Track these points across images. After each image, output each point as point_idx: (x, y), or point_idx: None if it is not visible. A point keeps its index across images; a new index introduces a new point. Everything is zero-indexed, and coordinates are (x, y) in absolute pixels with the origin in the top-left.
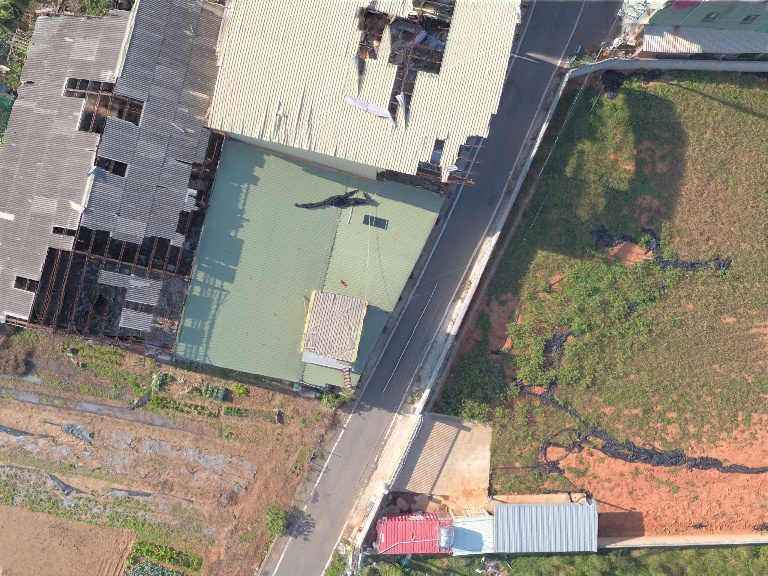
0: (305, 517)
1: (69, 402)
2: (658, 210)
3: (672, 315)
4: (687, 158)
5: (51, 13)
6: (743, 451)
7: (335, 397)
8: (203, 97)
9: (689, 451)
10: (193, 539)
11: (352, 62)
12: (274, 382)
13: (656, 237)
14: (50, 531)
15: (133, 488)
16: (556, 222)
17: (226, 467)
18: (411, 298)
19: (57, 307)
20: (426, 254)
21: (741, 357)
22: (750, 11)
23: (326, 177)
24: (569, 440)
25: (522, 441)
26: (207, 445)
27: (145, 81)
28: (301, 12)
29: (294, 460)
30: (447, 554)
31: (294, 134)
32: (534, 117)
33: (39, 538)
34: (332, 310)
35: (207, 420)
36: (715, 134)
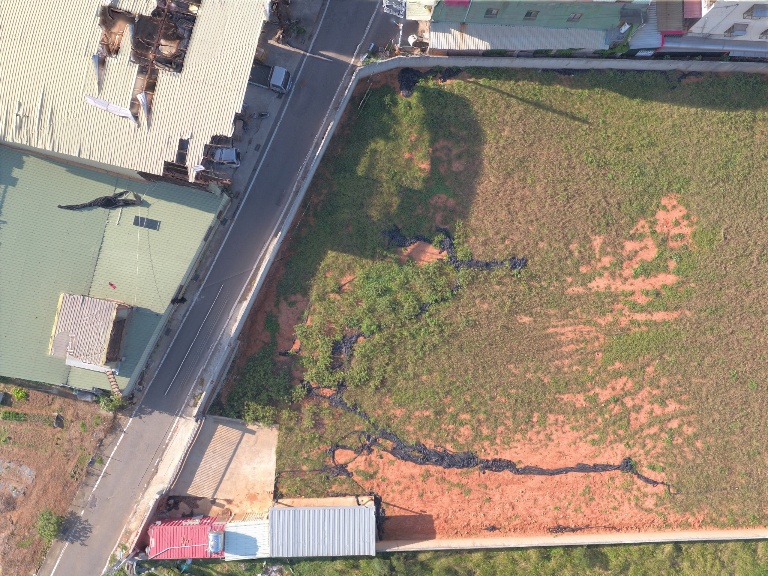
0: (82, 522)
1: None
2: (453, 209)
3: (465, 315)
4: (483, 156)
5: None
6: (538, 452)
7: (110, 400)
8: None
9: (482, 453)
10: None
11: (92, 61)
12: (54, 386)
13: (450, 236)
14: None
15: None
16: (347, 222)
17: (4, 472)
18: (196, 300)
19: None
20: (212, 255)
21: (537, 357)
22: (526, 7)
23: (92, 178)
24: (358, 442)
25: (309, 444)
26: None
27: None
28: (40, 11)
29: (73, 464)
30: (219, 559)
31: (36, 135)
32: (326, 116)
33: None
34: (80, 313)
35: None
36: (513, 132)
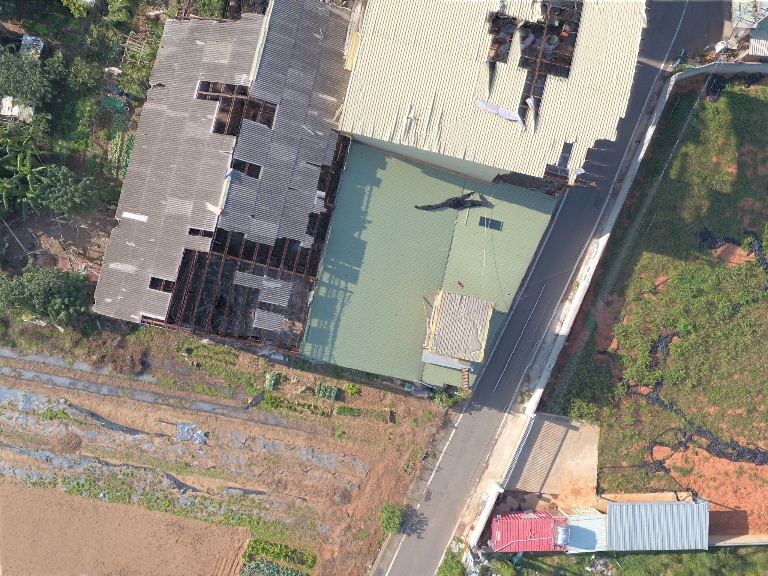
0: (418, 515)
1: (184, 401)
2: (760, 212)
3: None
4: None
5: (180, 16)
6: None
7: (449, 397)
8: (332, 100)
9: None
10: (307, 537)
11: (483, 66)
12: (385, 382)
13: (758, 239)
14: (167, 529)
15: (248, 486)
16: (660, 224)
17: (339, 466)
18: (519, 299)
19: (195, 308)
20: (534, 255)
21: None
22: None
23: (444, 179)
24: (674, 439)
25: (629, 440)
26: (320, 444)
27: (278, 84)
28: (432, 16)
29: (406, 459)
30: (562, 552)
31: (424, 137)
32: (638, 120)
33: (156, 536)
34: (459, 311)
35: (320, 419)
36: None
